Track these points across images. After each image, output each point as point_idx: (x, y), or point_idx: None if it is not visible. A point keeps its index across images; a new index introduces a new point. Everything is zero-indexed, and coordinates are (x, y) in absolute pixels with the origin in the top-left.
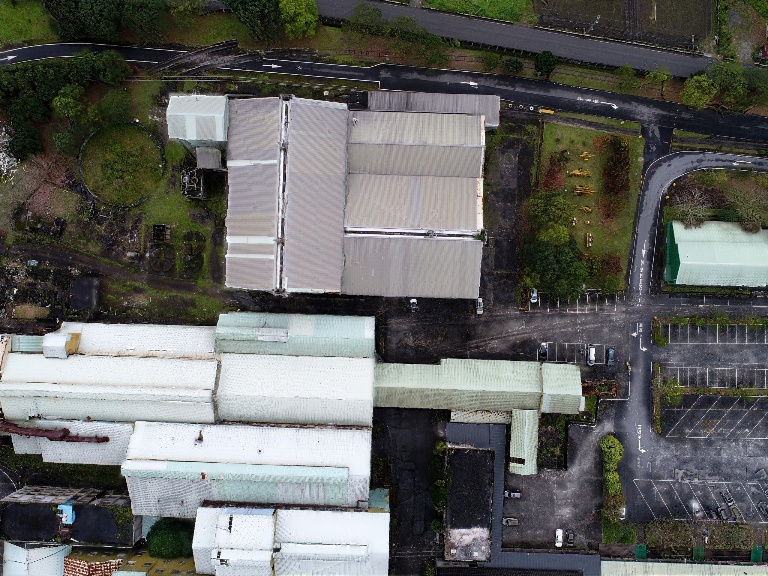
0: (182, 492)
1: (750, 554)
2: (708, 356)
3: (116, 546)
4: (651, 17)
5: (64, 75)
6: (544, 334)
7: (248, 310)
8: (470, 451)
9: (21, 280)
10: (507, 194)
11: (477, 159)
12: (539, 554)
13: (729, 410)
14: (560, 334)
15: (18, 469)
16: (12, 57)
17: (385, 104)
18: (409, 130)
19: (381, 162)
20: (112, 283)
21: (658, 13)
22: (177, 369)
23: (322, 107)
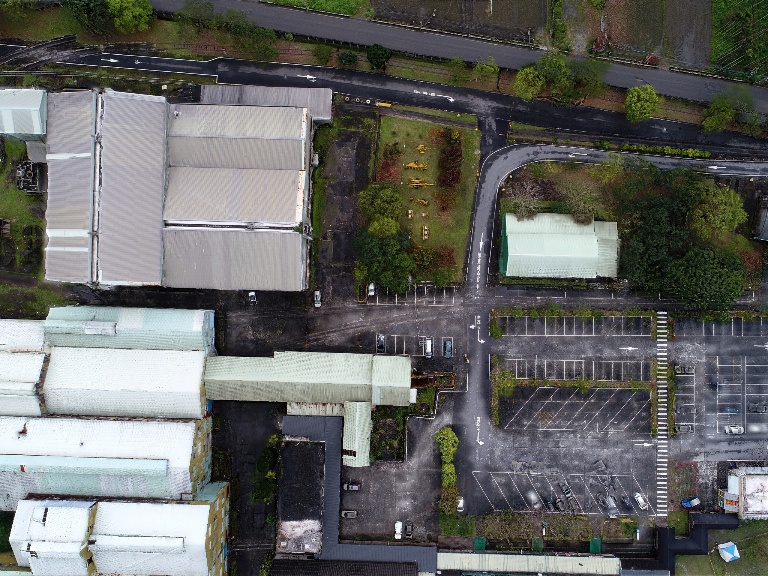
0: (6, 485)
1: (589, 545)
2: (546, 348)
3: None
4: (487, 10)
5: None
6: (382, 327)
7: (88, 304)
8: (301, 443)
9: None
10: (345, 187)
11: (298, 152)
12: (376, 546)
13: (567, 402)
14: (398, 327)
15: None
16: None
17: (218, 98)
18: (230, 123)
19: (203, 155)
20: None
21: (494, 6)
22: (3, 362)
23: (138, 100)
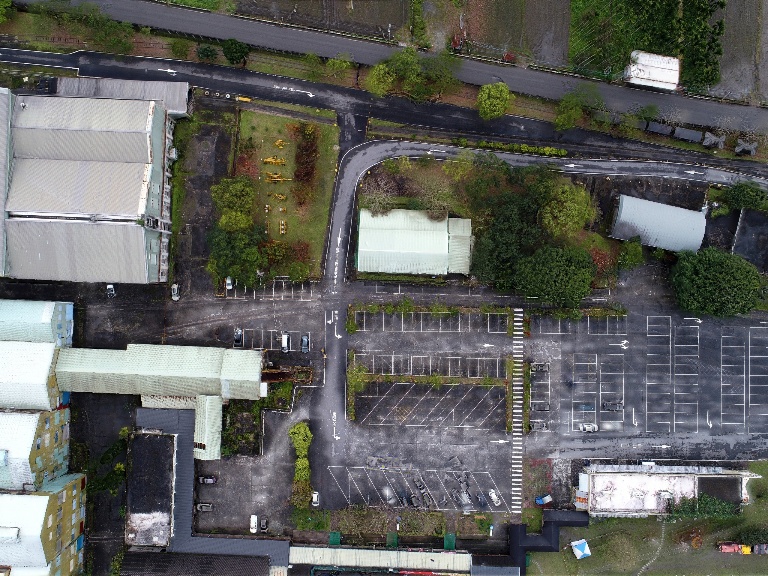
0: None
1: (443, 541)
2: (403, 344)
3: None
4: (348, 6)
5: None
6: (240, 321)
7: None
8: (150, 436)
9: None
10: (204, 181)
11: (144, 145)
12: (228, 539)
13: (423, 398)
14: (256, 321)
15: None
16: None
17: (74, 90)
18: (77, 115)
19: (50, 147)
20: None
21: (355, 2)
22: None
23: None
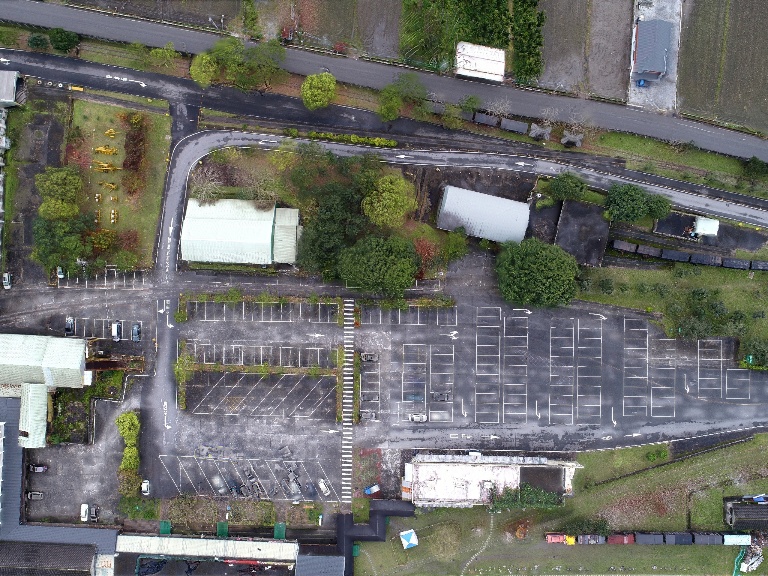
0: None
1: (273, 531)
2: (234, 333)
3: None
4: None
5: None
6: (72, 310)
7: None
8: None
9: None
10: (37, 170)
11: None
12: (56, 528)
13: (254, 387)
14: (88, 310)
15: None
16: None
17: None
18: None
19: None
20: None
21: None
22: None
23: None
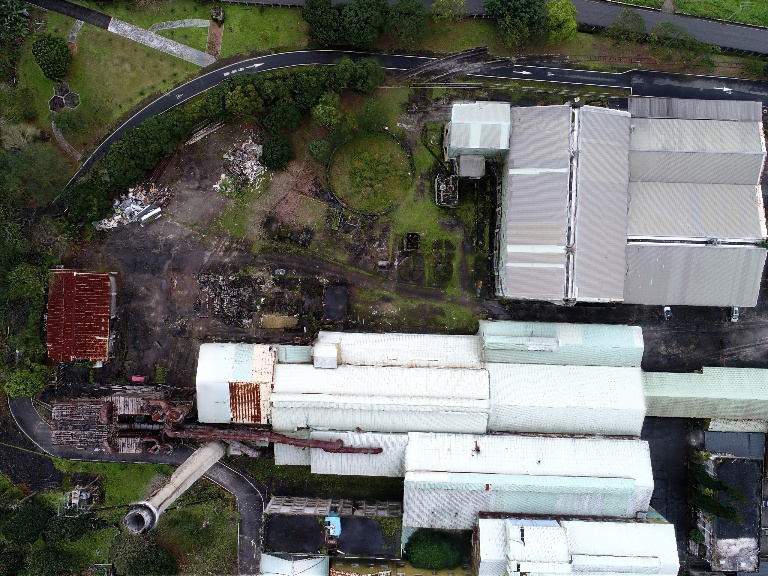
0: (458, 503)
1: None
2: None
3: (384, 558)
4: None
5: (322, 83)
6: None
7: (499, 319)
8: (737, 460)
9: (268, 289)
10: None
11: (757, 166)
12: None
13: None
14: None
15: (265, 480)
16: (258, 65)
17: (646, 111)
18: (687, 137)
19: (658, 169)
20: (360, 292)
21: None
22: (449, 379)
23: (609, 115)
